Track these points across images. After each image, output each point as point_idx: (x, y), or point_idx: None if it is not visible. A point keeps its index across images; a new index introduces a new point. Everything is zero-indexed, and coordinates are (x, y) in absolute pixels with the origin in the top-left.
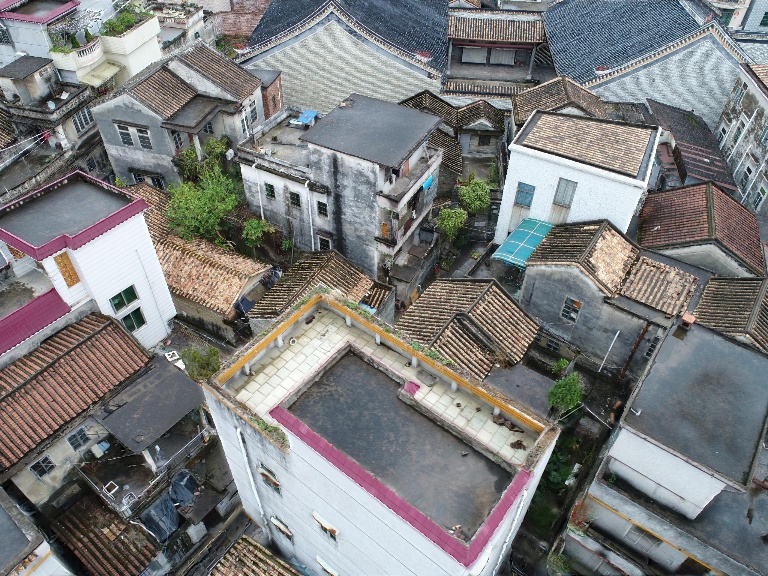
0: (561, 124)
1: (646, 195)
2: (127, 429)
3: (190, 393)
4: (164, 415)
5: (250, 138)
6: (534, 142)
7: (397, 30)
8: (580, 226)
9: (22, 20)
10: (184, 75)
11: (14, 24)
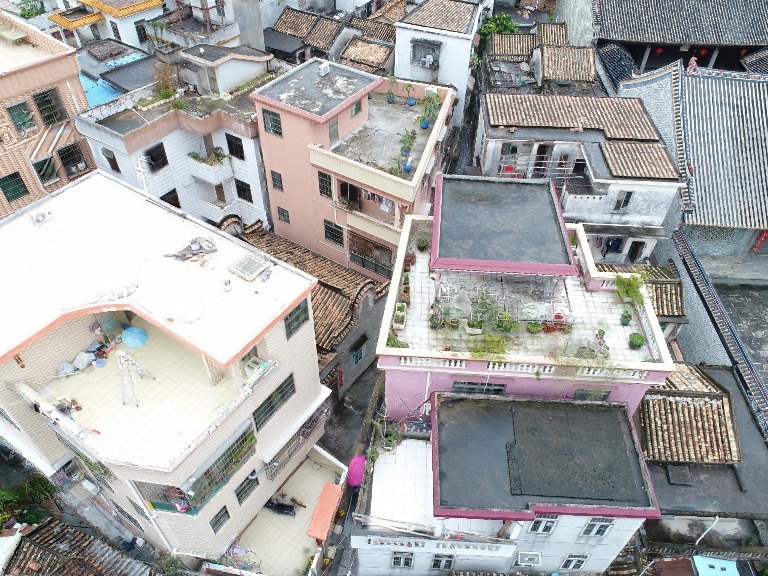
0: (462, 8)
1: (411, 47)
2: None
3: None
4: None
5: None
6: (436, 0)
7: (651, 3)
8: None
9: None
10: None
11: None
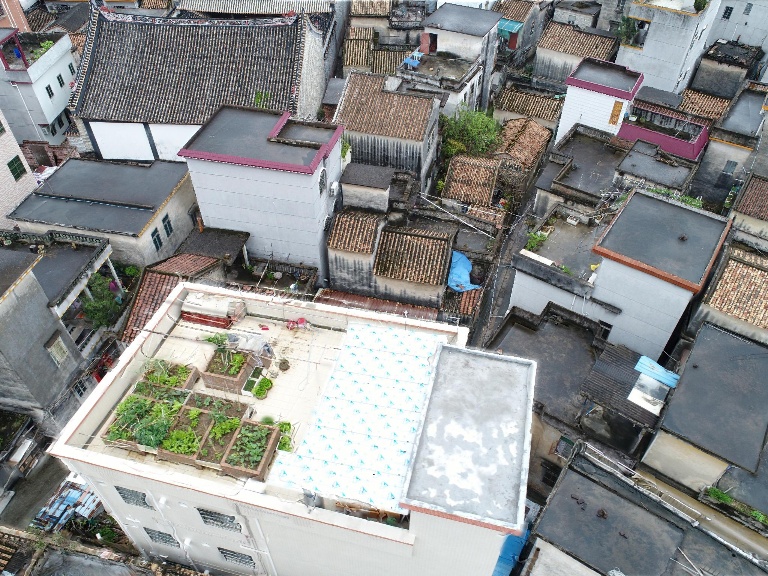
0: None
1: None
2: (675, 100)
3: (647, 89)
4: (662, 93)
5: (446, 78)
6: None
7: None
8: (498, 4)
9: (336, 141)
10: (389, 87)
11: (328, 156)
